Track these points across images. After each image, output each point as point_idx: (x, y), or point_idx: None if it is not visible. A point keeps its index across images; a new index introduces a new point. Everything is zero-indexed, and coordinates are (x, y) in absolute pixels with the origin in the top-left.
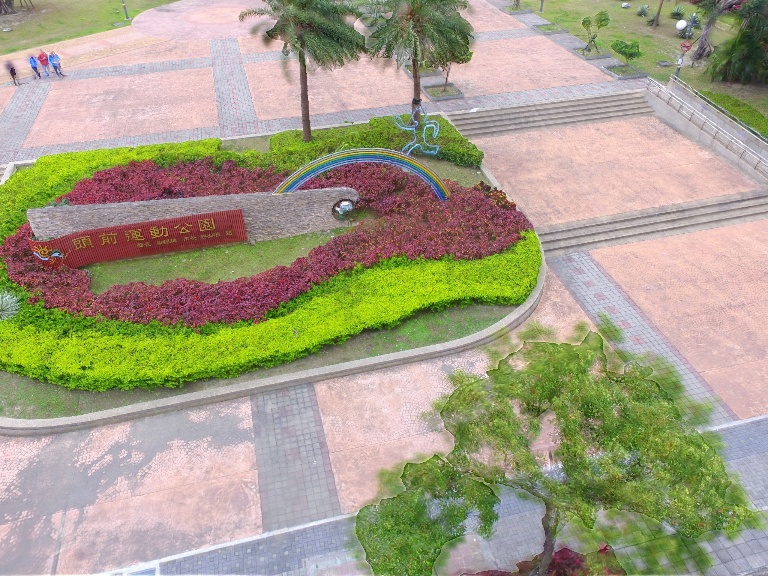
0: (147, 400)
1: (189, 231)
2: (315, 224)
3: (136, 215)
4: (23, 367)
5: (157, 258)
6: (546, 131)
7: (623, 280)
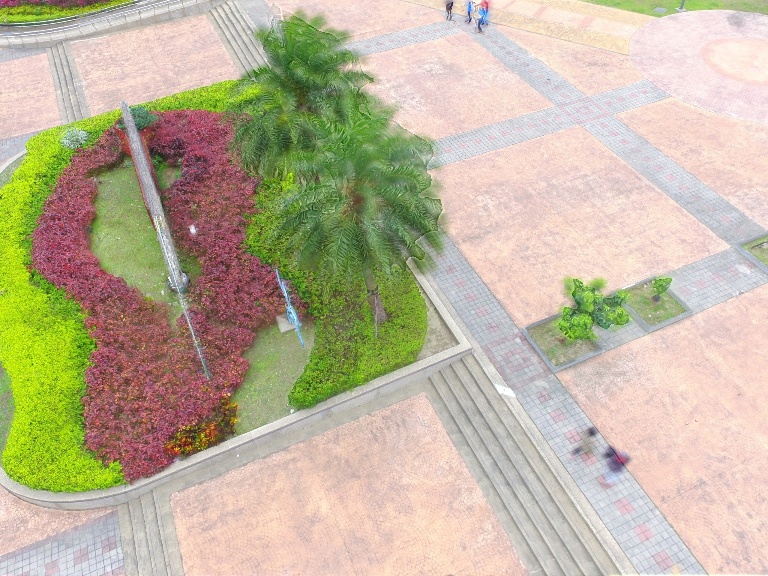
0: None
1: None
2: None
3: None
4: None
5: None
6: (491, 519)
7: None
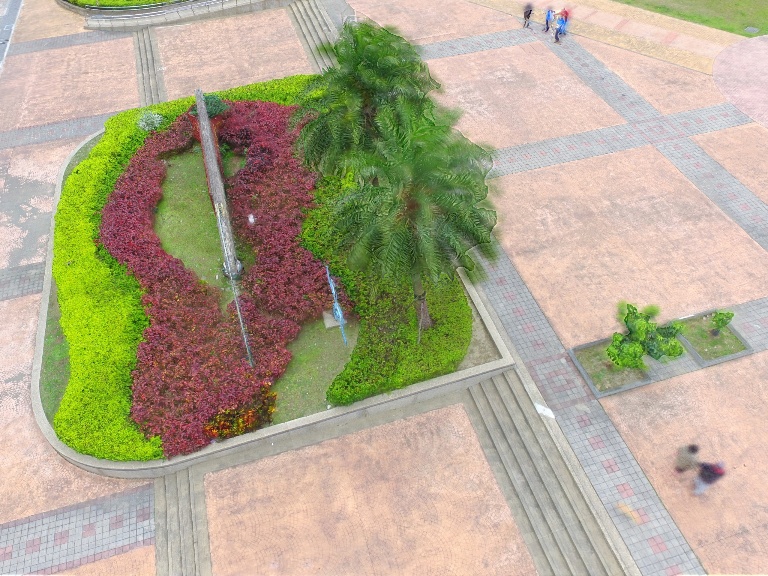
0: None
1: None
2: None
3: None
4: None
5: None
6: (517, 539)
7: (80, 575)
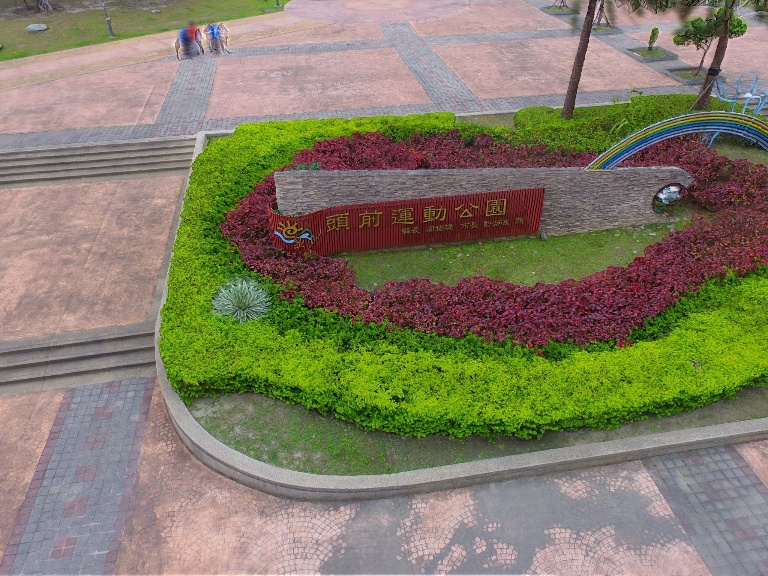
0: (489, 456)
1: (472, 215)
2: (626, 216)
3: (410, 188)
4: (297, 391)
5: (420, 250)
6: None
7: None
